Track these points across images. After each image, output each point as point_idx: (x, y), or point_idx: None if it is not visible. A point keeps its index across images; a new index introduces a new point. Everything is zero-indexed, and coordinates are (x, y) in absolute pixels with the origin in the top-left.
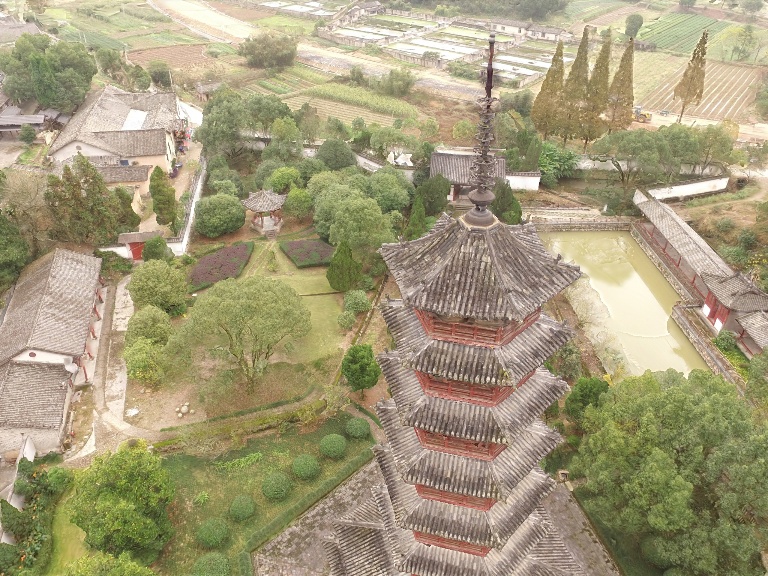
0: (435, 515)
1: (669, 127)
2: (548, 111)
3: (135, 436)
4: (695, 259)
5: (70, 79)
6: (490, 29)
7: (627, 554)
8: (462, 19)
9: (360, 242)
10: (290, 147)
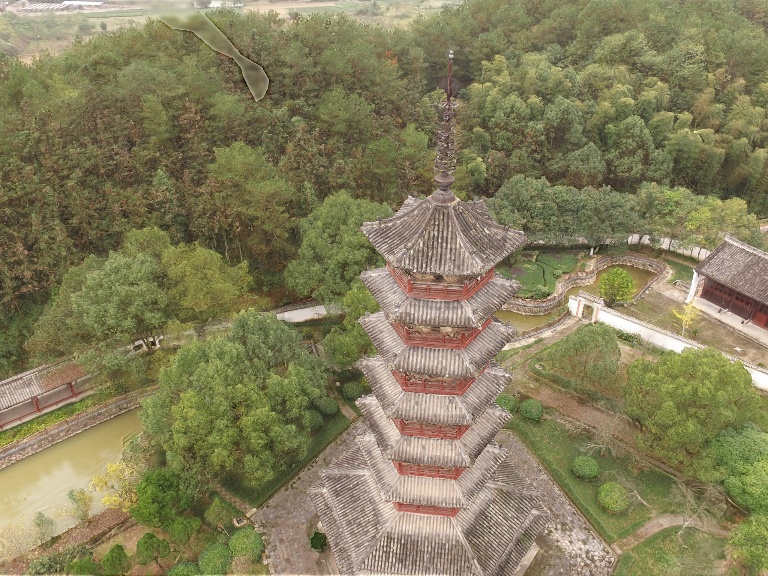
0: None
1: None
2: None
3: None
4: None
5: None
6: None
7: None
8: None
9: None
10: None
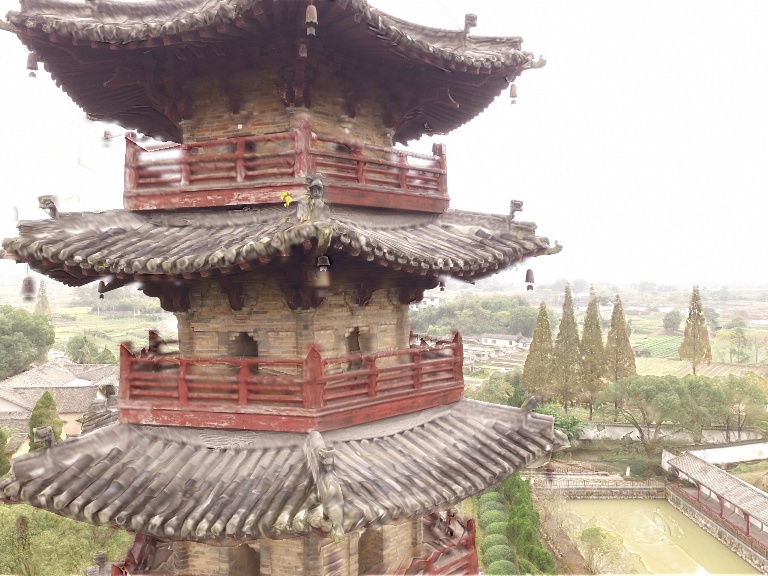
0: None
1: (683, 378)
2: (540, 373)
3: None
4: None
5: (16, 343)
6: (481, 343)
7: None
8: None
9: None
10: None
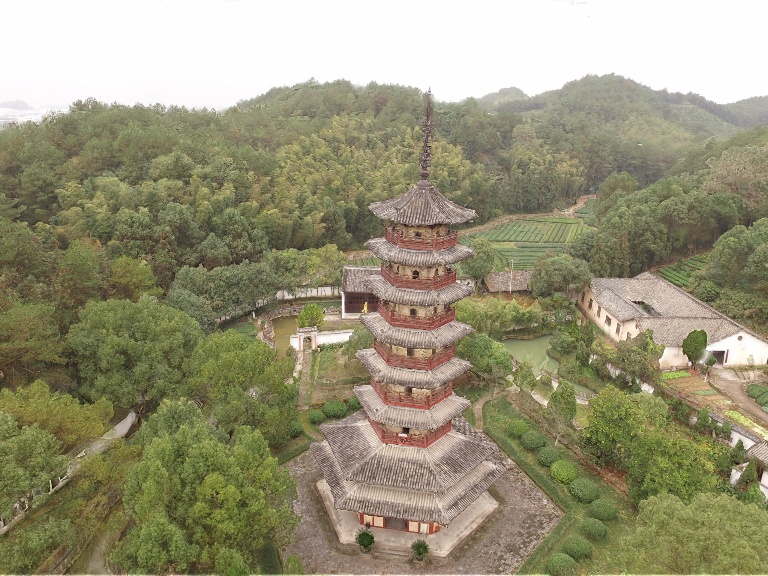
0: None
1: None
2: None
3: None
4: None
5: None
6: None
7: None
8: None
9: None
10: None
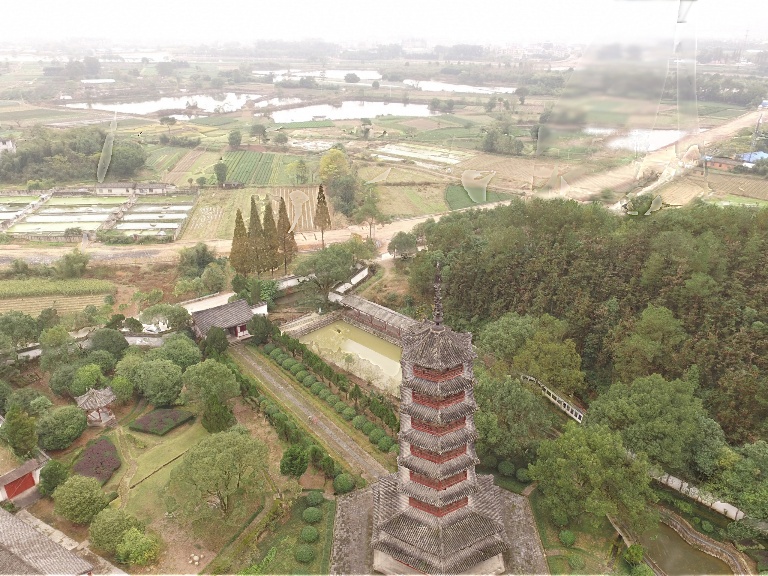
0: (449, 468)
1: (330, 248)
2: (245, 257)
3: None
4: (396, 321)
5: None
6: (96, 194)
7: (479, 472)
8: (60, 189)
9: (218, 392)
10: (67, 349)
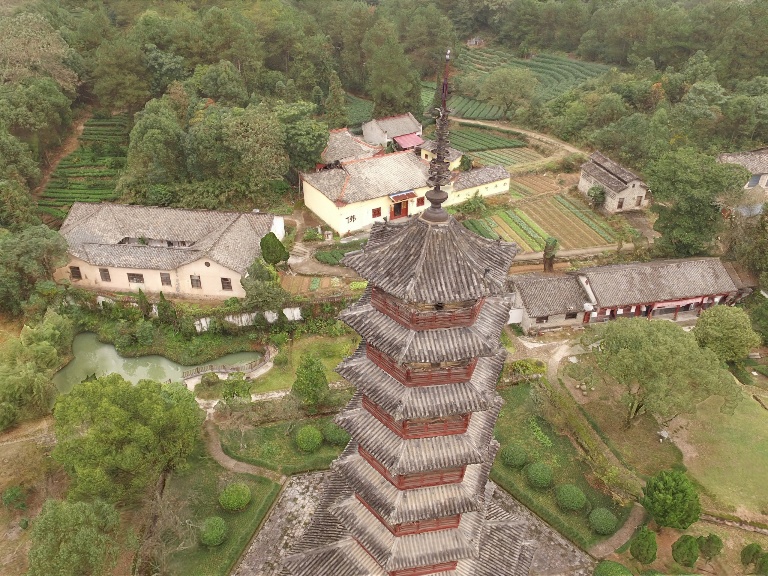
0: None
1: None
2: None
3: (549, 365)
4: None
5: None
6: None
7: None
8: None
9: None
10: None
